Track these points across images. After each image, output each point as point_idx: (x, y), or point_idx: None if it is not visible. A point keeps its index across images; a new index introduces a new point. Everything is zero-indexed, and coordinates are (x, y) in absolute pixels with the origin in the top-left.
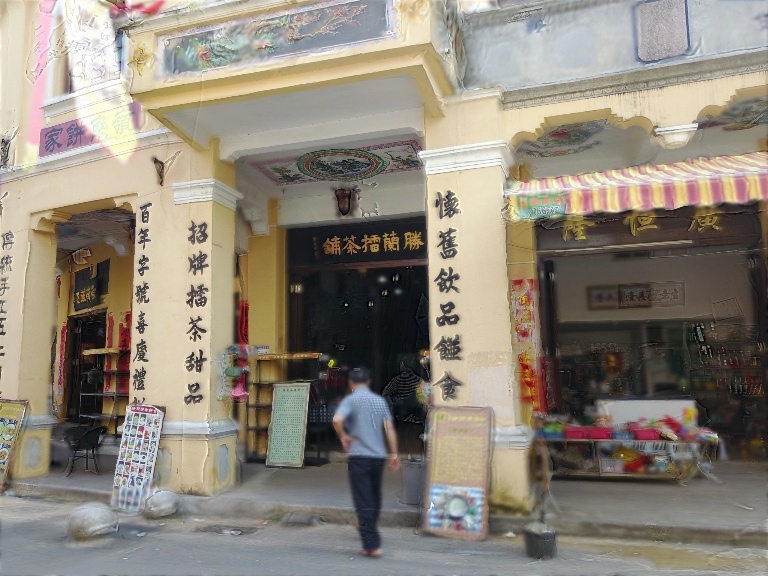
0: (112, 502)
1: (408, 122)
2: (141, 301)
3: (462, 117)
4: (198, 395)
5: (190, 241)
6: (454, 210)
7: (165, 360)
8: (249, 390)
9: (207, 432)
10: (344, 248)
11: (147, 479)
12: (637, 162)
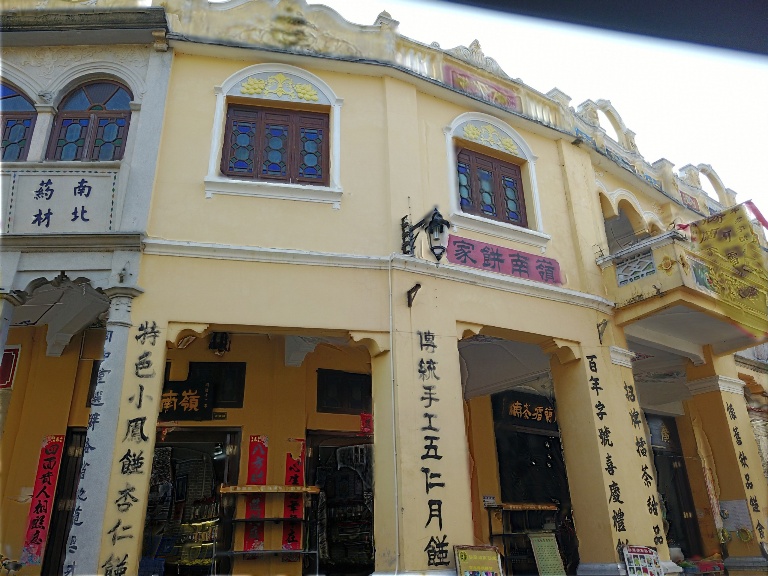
0: None
1: (697, 352)
2: (605, 444)
3: (726, 361)
4: None
5: (627, 398)
6: (734, 416)
7: (636, 502)
8: None
9: (680, 570)
10: (524, 413)
11: None
12: (675, 398)
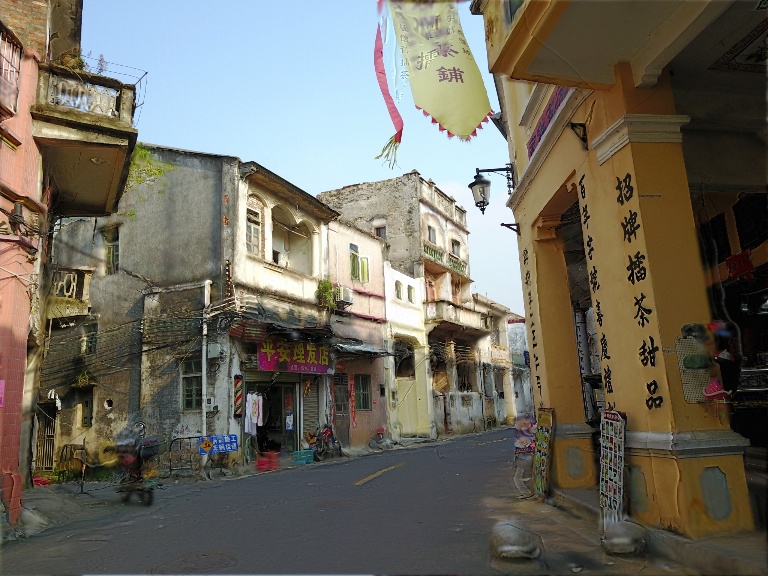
0: (600, 525)
1: None
2: (595, 288)
3: None
4: (658, 397)
5: (619, 202)
6: None
7: (622, 355)
8: (731, 387)
9: (669, 447)
10: None
11: (619, 503)
12: None
